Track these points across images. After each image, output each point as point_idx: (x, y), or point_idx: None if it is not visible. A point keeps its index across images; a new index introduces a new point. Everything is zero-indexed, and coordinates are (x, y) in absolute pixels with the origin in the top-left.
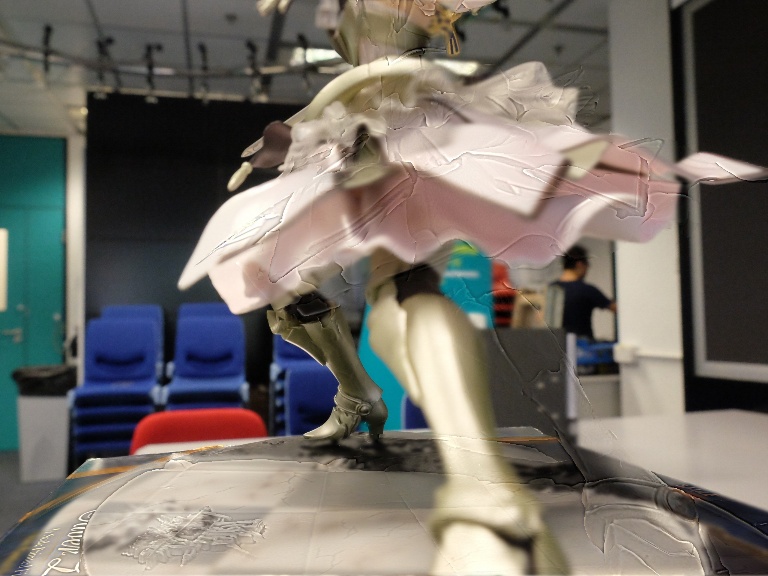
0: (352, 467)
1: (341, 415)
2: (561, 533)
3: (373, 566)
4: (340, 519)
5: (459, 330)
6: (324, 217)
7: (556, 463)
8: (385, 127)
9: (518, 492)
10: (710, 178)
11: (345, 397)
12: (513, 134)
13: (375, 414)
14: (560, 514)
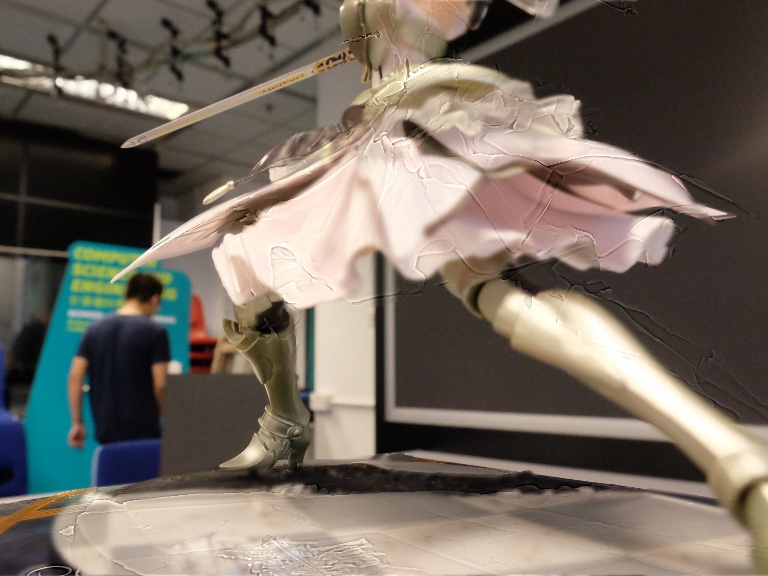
0: (315, 493)
1: (267, 440)
2: (630, 522)
3: (552, 564)
4: (418, 534)
5: (594, 323)
6: (510, 196)
7: (509, 474)
8: (468, 123)
9: (524, 498)
10: (680, 214)
11: (277, 419)
12: (591, 149)
13: (301, 438)
14: (600, 509)
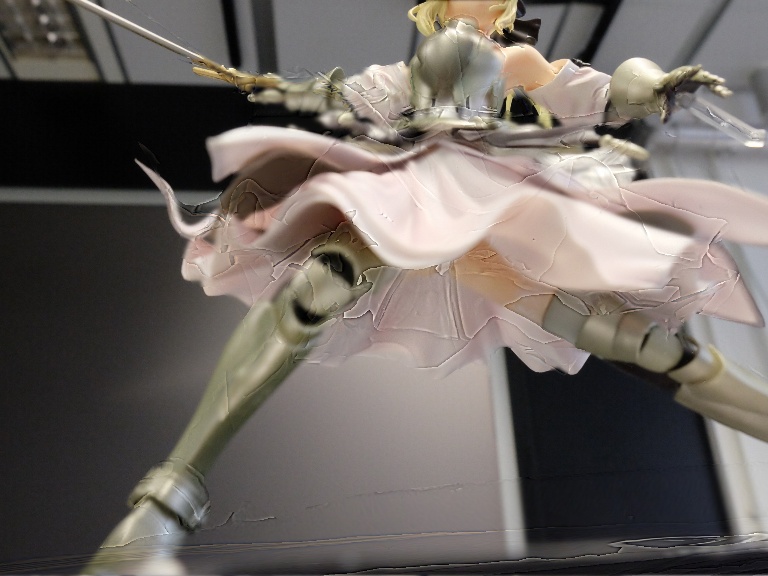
0: None
1: (169, 521)
2: None
3: None
4: None
5: None
6: None
7: None
8: None
9: None
10: None
11: (202, 479)
12: None
13: None
14: None
